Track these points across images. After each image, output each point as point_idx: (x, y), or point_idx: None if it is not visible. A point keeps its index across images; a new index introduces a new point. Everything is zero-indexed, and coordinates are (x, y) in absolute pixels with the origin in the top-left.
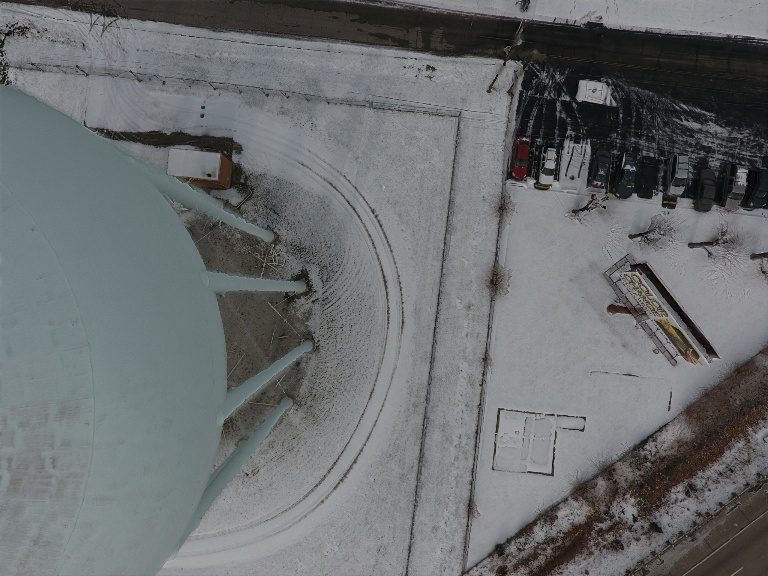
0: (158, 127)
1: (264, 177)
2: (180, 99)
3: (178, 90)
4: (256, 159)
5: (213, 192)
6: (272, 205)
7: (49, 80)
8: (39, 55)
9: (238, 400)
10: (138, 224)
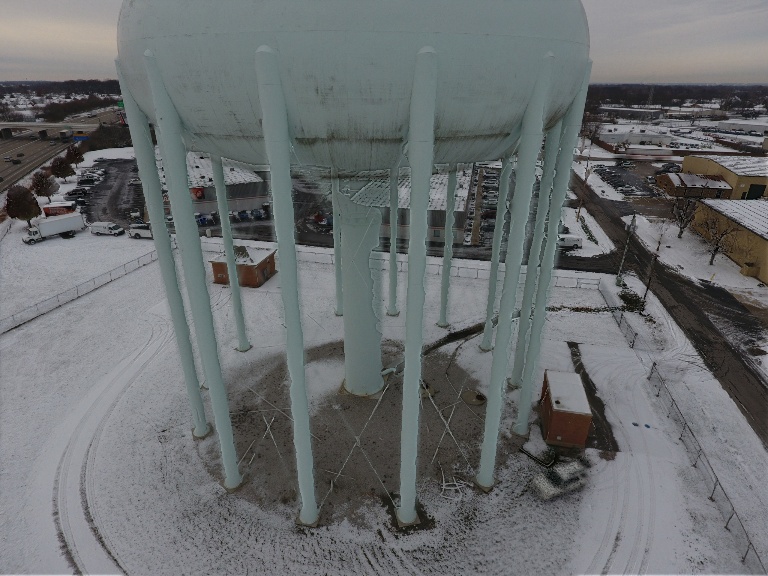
0: (601, 388)
1: (576, 482)
2: (646, 407)
3: (657, 406)
4: (600, 474)
5: (537, 427)
6: (535, 489)
7: (612, 328)
8: (633, 326)
9: (275, 134)
10: (486, 5)
